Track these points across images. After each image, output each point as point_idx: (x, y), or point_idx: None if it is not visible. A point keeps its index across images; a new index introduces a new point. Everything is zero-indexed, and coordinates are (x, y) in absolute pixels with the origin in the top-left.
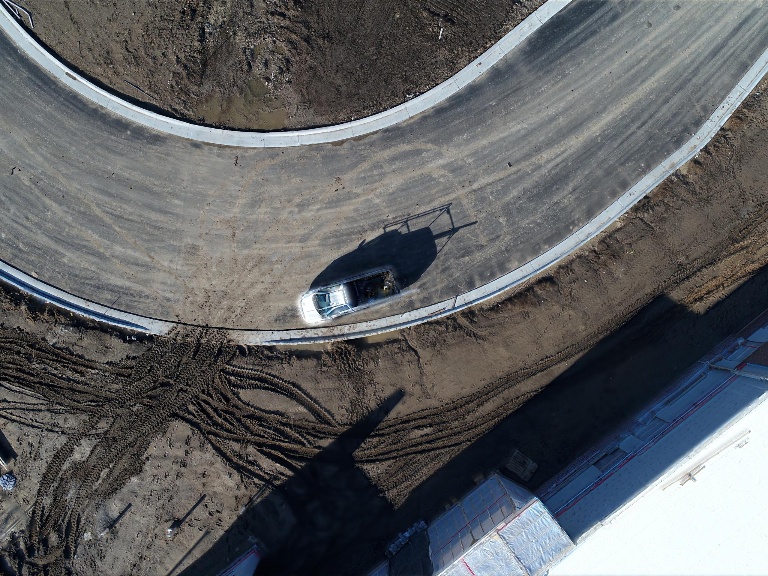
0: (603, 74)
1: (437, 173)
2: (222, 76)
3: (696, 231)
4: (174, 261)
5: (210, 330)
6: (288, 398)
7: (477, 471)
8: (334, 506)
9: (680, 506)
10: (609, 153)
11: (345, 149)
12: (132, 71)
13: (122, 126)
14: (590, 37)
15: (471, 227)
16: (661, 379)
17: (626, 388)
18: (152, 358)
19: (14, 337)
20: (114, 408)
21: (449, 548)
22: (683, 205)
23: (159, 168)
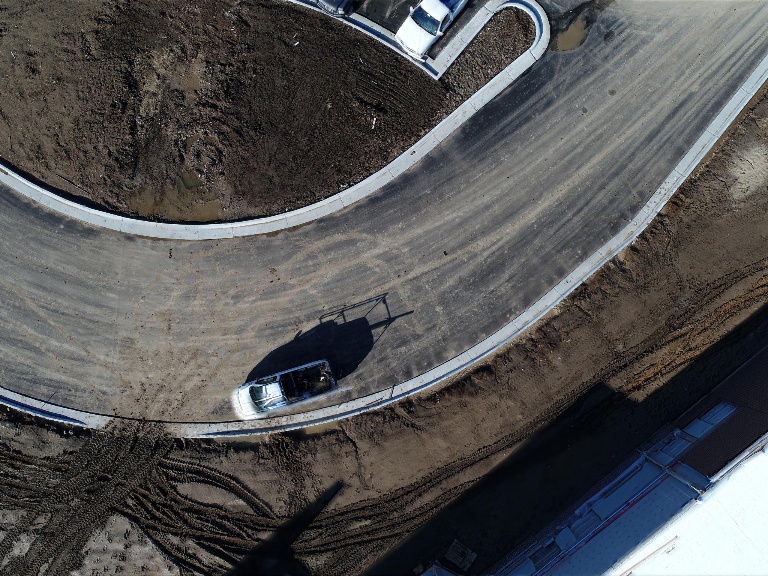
0: (539, 161)
1: (372, 263)
2: (155, 168)
3: (633, 318)
4: (110, 355)
5: (147, 423)
6: (226, 491)
7: (416, 561)
8: None
9: None
10: (545, 240)
11: (280, 240)
12: (64, 165)
13: (55, 220)
14: (525, 123)
15: (407, 317)
16: (599, 467)
17: (564, 477)
18: (89, 453)
19: None
20: (52, 503)
21: None
22: (620, 292)
23: (93, 262)
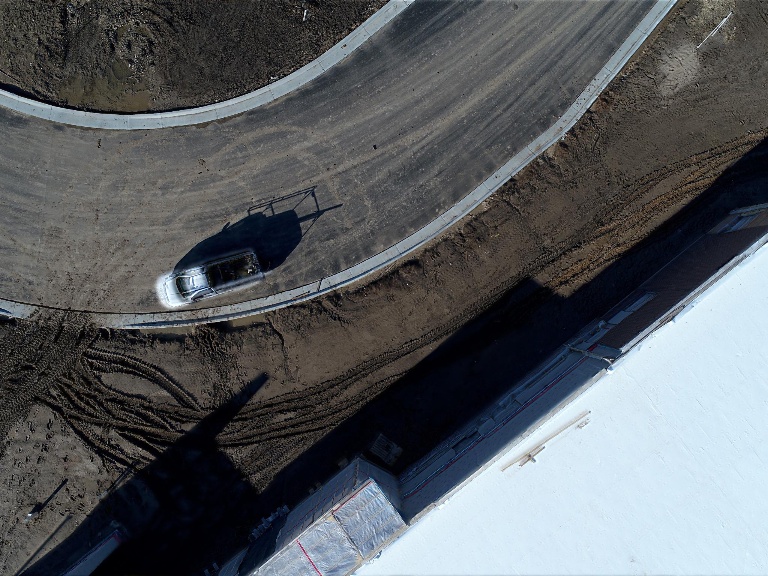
0: (469, 56)
1: (302, 155)
2: (85, 58)
3: (561, 214)
4: (37, 244)
5: (73, 313)
6: (150, 382)
7: (341, 455)
8: (197, 490)
9: (520, 487)
10: (475, 135)
11: (209, 131)
12: None
13: None
14: (456, 19)
15: (336, 210)
16: (526, 362)
17: (491, 372)
18: (13, 341)
19: None
20: None
21: (293, 530)
22: (548, 188)
23: (22, 150)
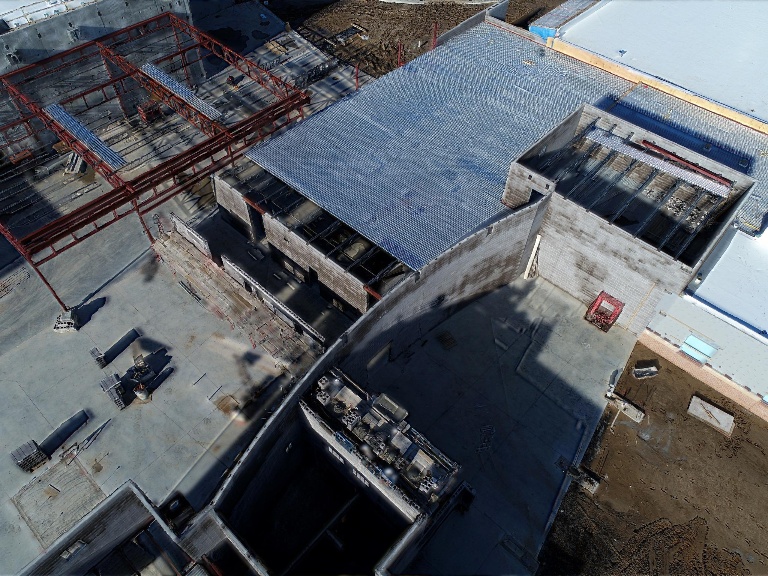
0: None
1: None
2: None
3: None
4: None
5: (446, 1)
6: None
7: None
8: None
9: None
10: None
11: None
12: None
13: None
14: None
15: None
16: None
17: None
18: None
19: (359, 5)
20: None
21: None
22: None
23: None
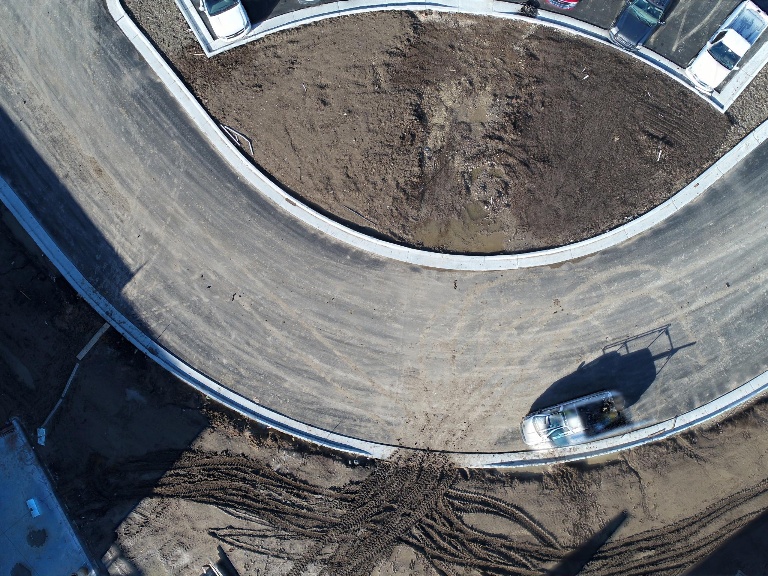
0: None
1: (655, 294)
2: (441, 200)
3: None
4: (395, 385)
5: (431, 454)
6: (511, 521)
7: None
8: None
9: None
10: None
11: (564, 271)
12: (352, 196)
13: (342, 251)
14: None
15: (690, 348)
16: None
17: None
18: (375, 483)
19: (238, 463)
20: (339, 533)
21: None
22: None
23: (379, 292)
